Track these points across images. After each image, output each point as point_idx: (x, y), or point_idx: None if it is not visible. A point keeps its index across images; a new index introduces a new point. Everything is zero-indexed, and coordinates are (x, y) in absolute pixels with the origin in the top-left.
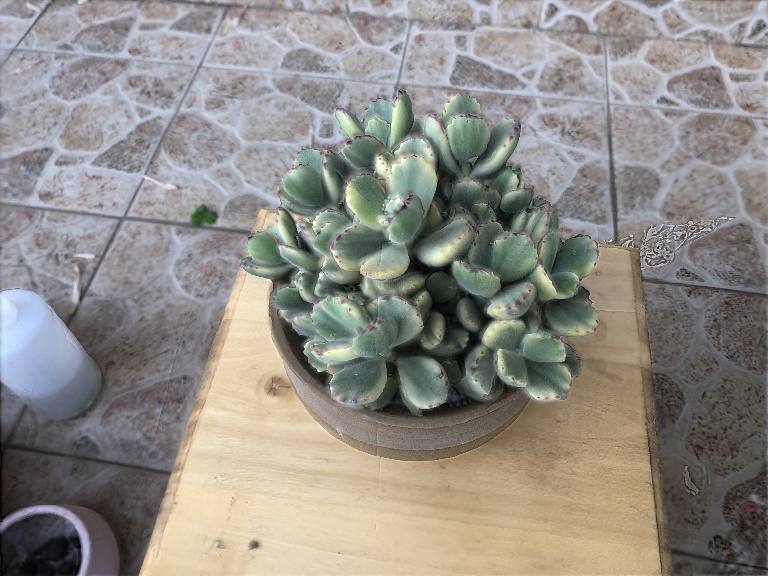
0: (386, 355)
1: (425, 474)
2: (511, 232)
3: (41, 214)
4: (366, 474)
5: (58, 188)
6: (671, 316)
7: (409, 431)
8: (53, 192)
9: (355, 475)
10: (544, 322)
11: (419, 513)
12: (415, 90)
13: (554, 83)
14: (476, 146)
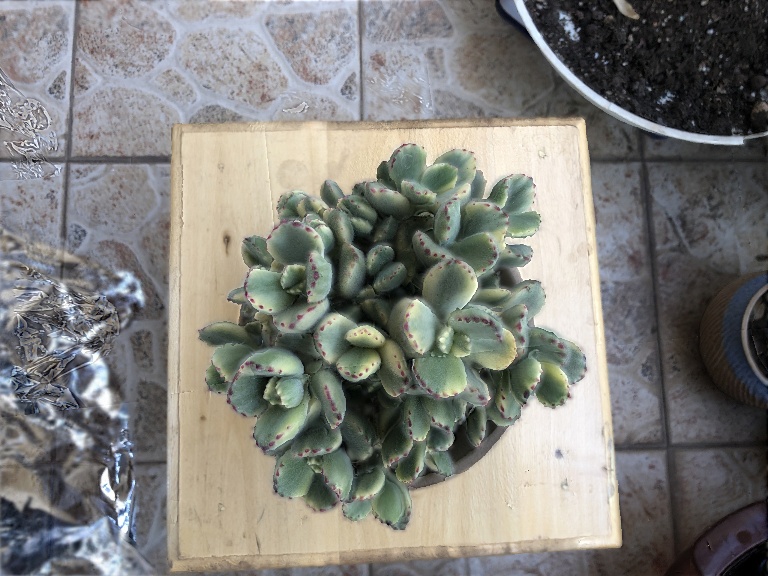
0: None
1: None
2: (384, 231)
3: None
4: None
5: None
6: (116, 109)
7: None
8: None
9: None
10: None
11: None
12: None
13: None
14: None
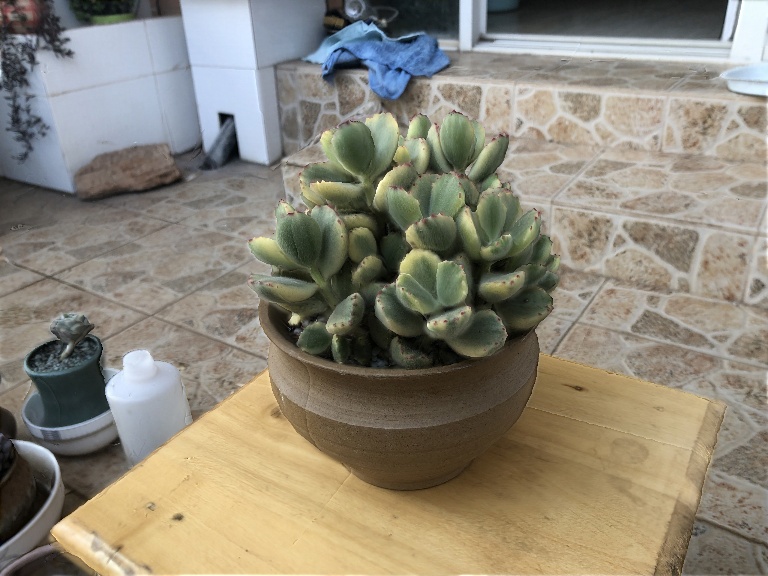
0: (319, 282)
1: (373, 516)
2: None
3: (230, 350)
4: (316, 498)
5: (253, 337)
6: None
7: (335, 395)
8: (247, 338)
9: (305, 495)
10: (475, 283)
11: (346, 546)
12: (592, 329)
13: (749, 350)
14: (458, 138)
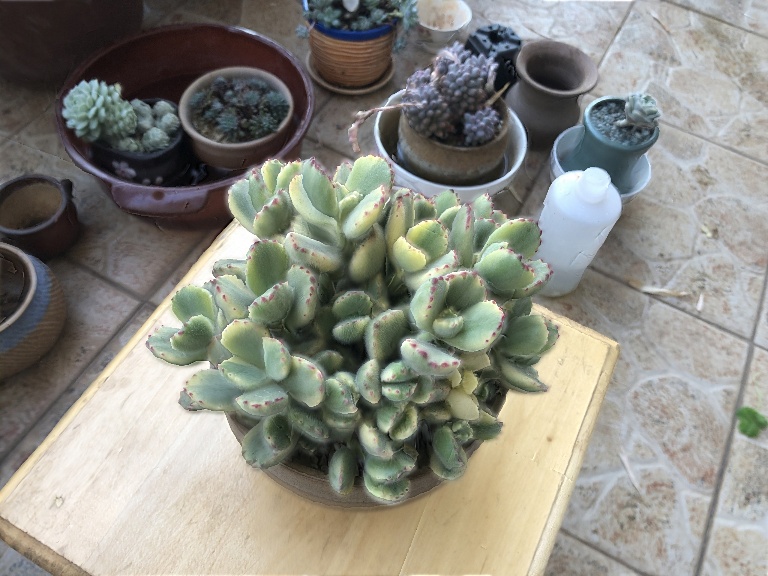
0: None
1: None
2: (329, 353)
3: (760, 273)
4: None
5: None
6: None
7: None
8: None
9: None
10: None
11: None
12: None
13: None
14: None
